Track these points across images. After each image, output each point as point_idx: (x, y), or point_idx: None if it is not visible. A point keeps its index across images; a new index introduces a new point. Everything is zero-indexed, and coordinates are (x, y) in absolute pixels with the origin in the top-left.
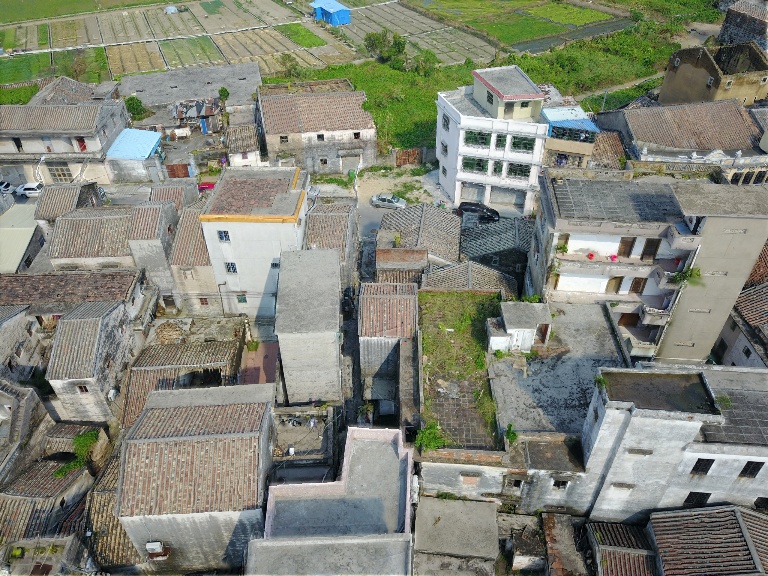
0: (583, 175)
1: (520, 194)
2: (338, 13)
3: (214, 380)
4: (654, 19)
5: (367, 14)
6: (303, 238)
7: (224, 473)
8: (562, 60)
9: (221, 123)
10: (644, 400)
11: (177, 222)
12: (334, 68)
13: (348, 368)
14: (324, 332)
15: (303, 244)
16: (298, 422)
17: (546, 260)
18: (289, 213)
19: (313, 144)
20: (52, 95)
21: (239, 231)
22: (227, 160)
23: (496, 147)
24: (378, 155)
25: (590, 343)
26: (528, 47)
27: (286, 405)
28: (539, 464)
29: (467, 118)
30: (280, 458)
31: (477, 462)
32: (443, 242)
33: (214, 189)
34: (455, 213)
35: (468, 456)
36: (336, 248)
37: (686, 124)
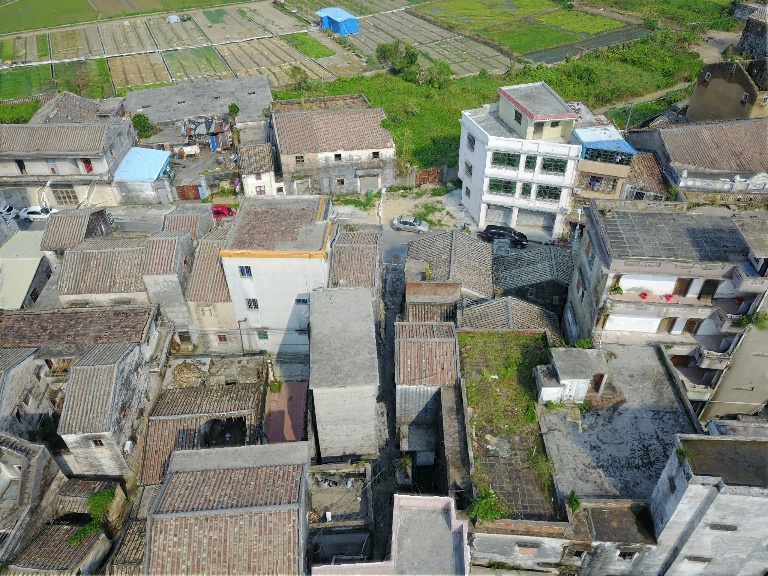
0: (632, 207)
1: (548, 216)
2: (346, 22)
3: (237, 428)
4: (669, 27)
5: (375, 23)
6: (329, 272)
7: (261, 552)
8: (580, 71)
9: (231, 140)
10: (731, 473)
11: (193, 253)
12: (345, 80)
13: (382, 416)
14: (363, 386)
15: (329, 278)
16: (334, 482)
17: (597, 300)
18: (316, 247)
19: (330, 164)
20: (55, 112)
21: (262, 266)
22: (240, 181)
23: (525, 169)
24: (397, 175)
25: (647, 391)
26: (542, 57)
27: (318, 459)
28: (605, 535)
29: (495, 139)
30: (317, 525)
31: (537, 533)
32: (476, 273)
33: (234, 220)
34: (480, 236)
35: (527, 527)
36: (365, 283)
37: (725, 144)
